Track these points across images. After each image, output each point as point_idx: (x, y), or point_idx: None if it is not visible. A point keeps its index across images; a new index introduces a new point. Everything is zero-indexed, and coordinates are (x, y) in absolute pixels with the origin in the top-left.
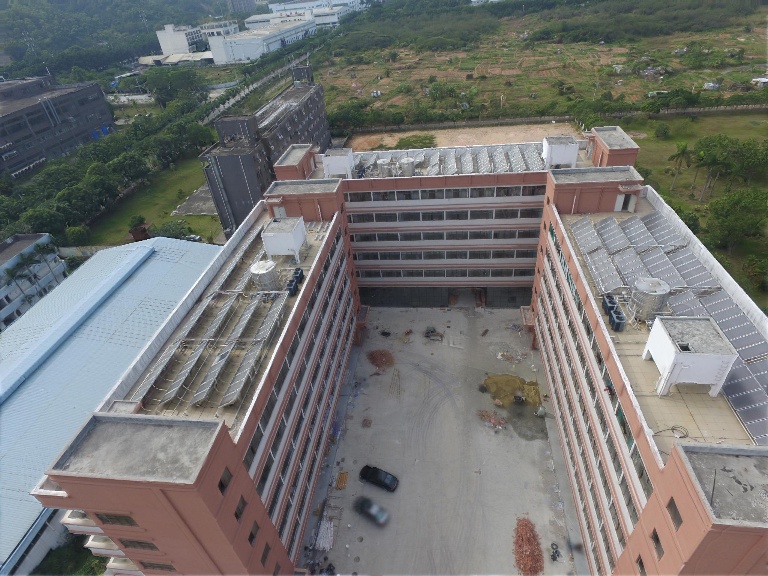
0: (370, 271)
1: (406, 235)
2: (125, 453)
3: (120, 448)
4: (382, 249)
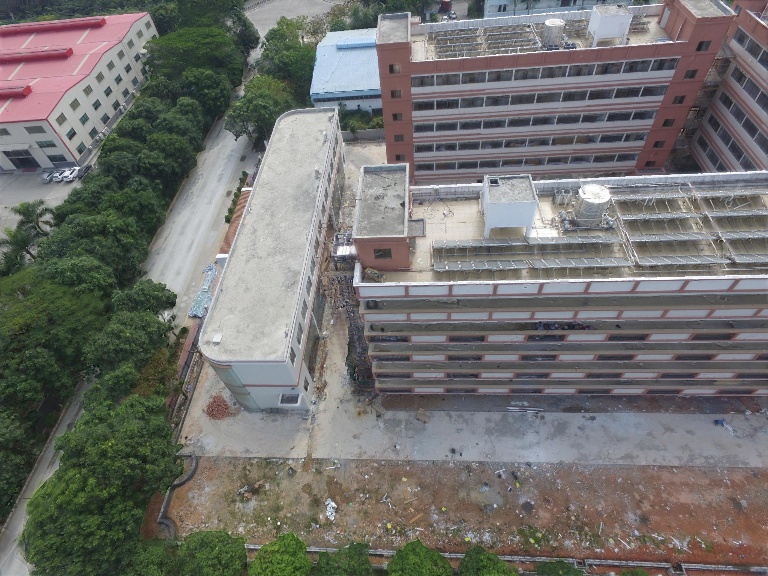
0: (715, 154)
1: (763, 138)
2: (392, 29)
3: (395, 27)
4: (737, 137)
